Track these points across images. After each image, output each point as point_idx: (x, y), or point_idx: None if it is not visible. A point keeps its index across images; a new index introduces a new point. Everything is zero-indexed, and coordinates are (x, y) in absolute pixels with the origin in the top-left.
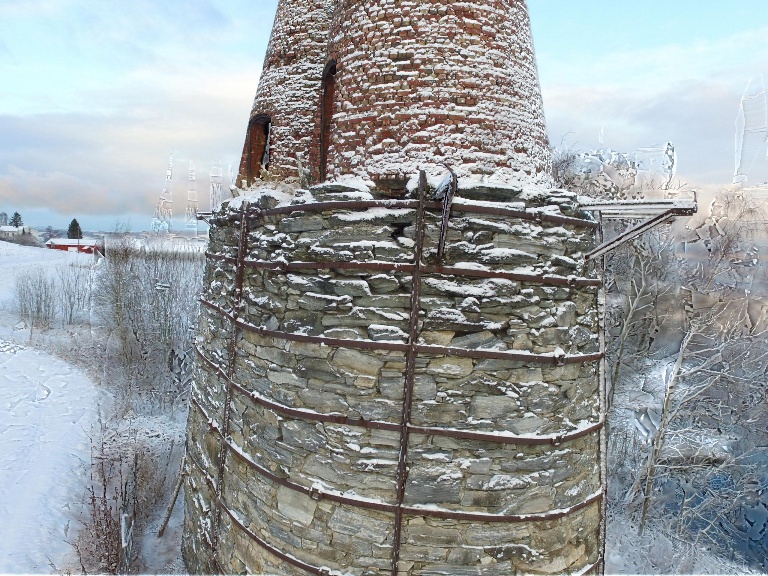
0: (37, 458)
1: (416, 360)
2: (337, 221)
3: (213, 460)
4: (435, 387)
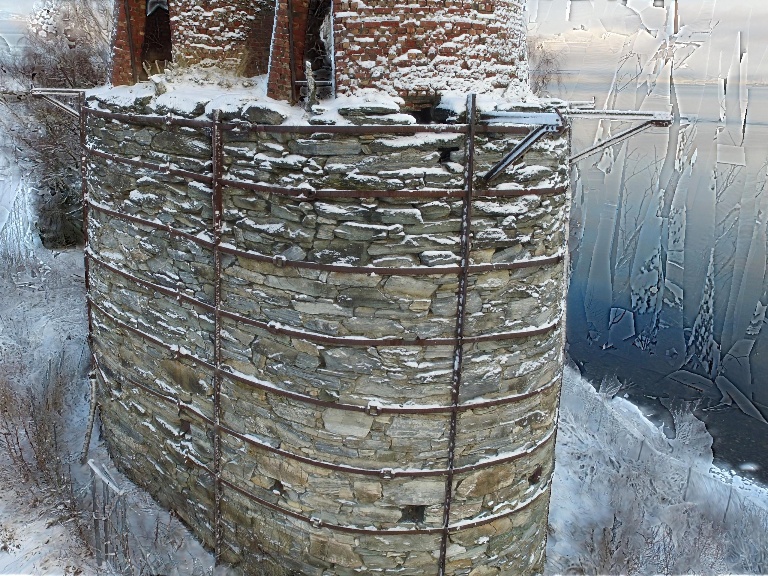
0: None
1: (467, 279)
2: (382, 147)
3: (187, 387)
4: (481, 300)
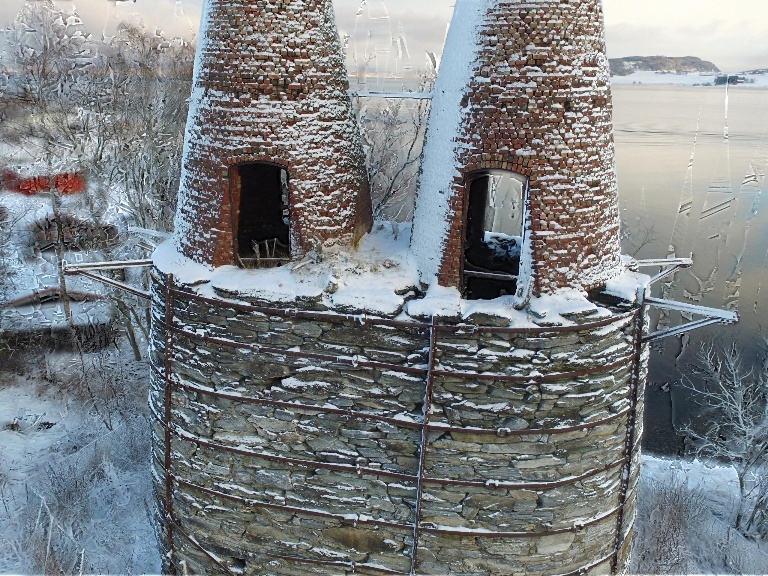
0: None
1: None
2: (596, 337)
3: (366, 548)
4: None
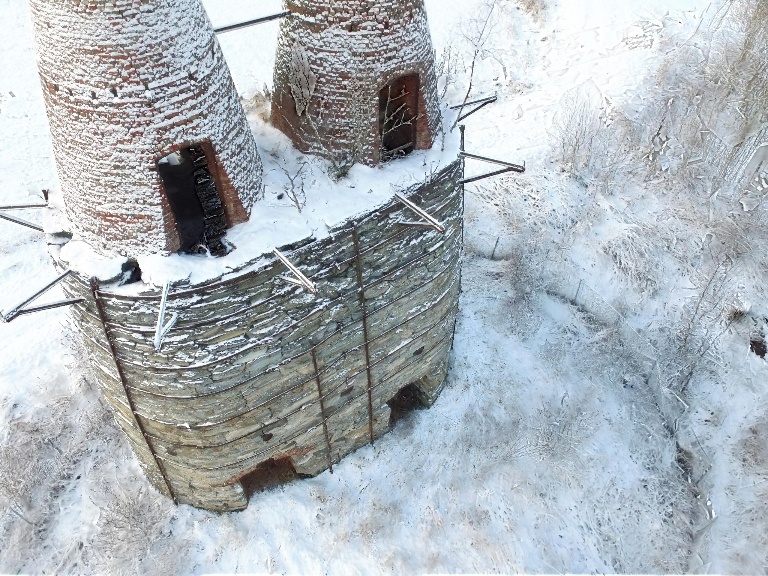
0: None
1: None
2: None
3: None
4: None
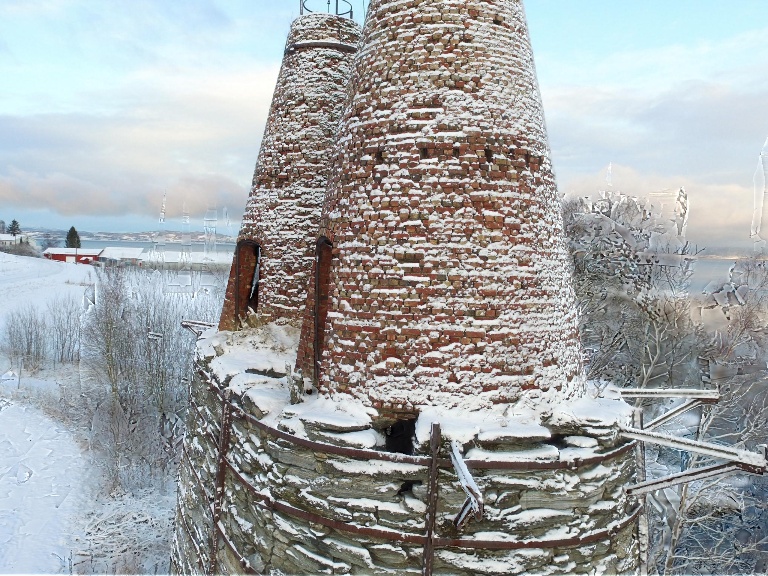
0: (14, 560)
1: None
2: (332, 470)
3: None
4: None
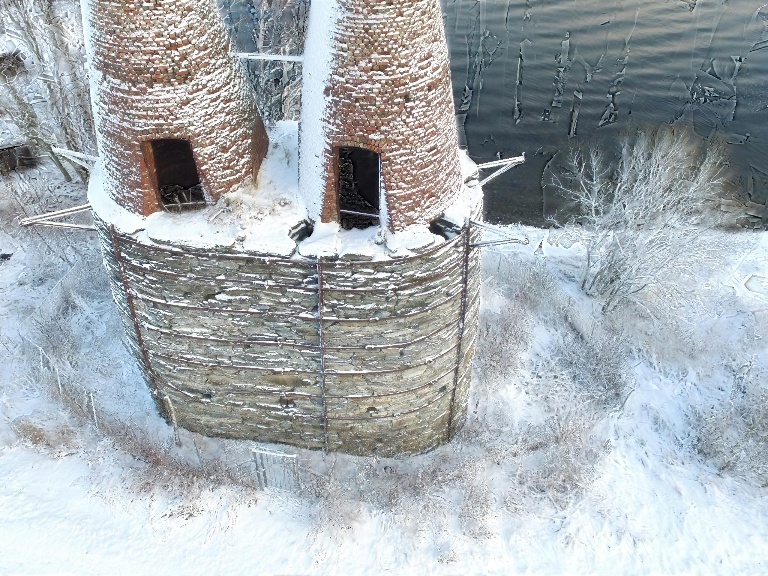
0: None
1: None
2: None
3: None
4: None
